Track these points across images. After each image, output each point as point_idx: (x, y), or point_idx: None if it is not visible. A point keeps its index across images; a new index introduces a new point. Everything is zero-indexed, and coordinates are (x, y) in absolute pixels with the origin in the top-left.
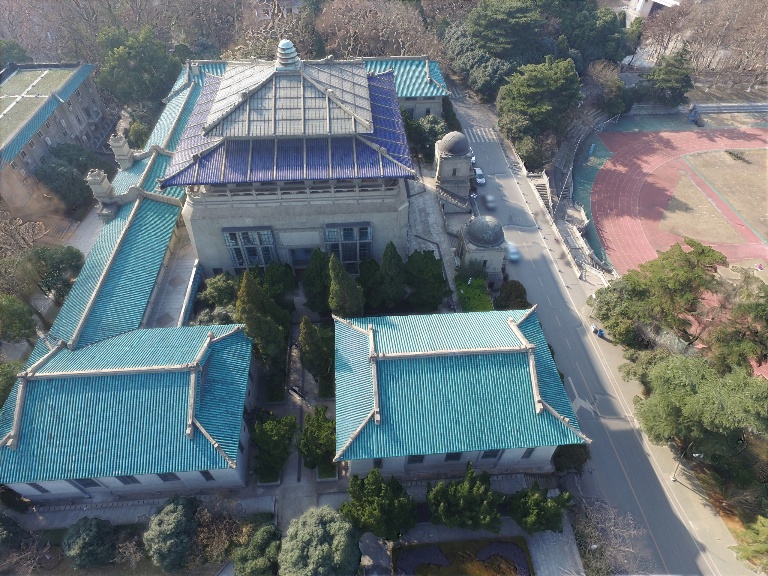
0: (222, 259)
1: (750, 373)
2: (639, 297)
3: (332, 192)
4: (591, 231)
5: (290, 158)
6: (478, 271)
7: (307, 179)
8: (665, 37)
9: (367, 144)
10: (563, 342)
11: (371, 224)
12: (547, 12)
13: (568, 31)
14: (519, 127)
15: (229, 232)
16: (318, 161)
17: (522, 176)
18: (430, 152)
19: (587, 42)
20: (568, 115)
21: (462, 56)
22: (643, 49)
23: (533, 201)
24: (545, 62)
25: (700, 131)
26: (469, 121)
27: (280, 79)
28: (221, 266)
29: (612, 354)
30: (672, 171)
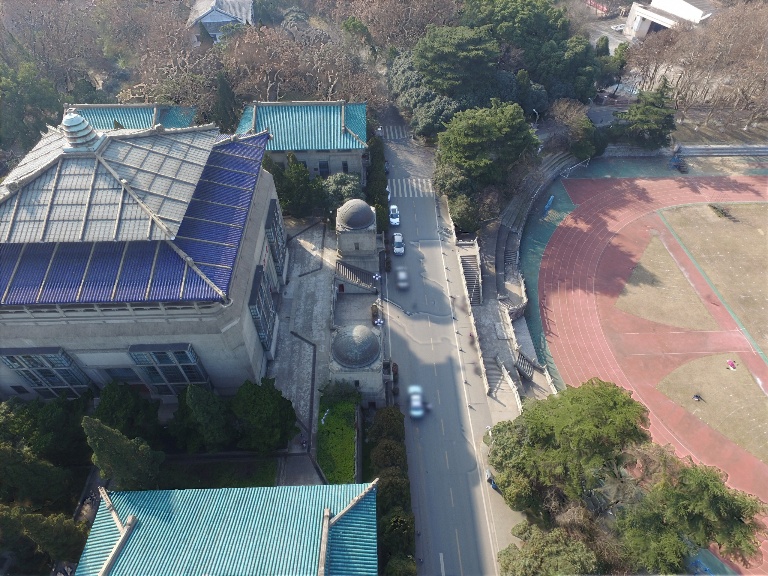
0: (17, 377)
1: (678, 568)
2: (543, 444)
3: (130, 310)
4: (533, 309)
5: (68, 269)
6: (346, 394)
7: (80, 301)
8: (651, 67)
9: (174, 250)
10: (446, 495)
11: (189, 347)
12: (508, 42)
13: (533, 63)
14: (453, 184)
15: (4, 355)
16: (103, 275)
17: (451, 244)
18: (335, 218)
19: (554, 76)
20: (525, 162)
21: (406, 92)
22: (626, 80)
23: (456, 279)
24: (502, 99)
25: (683, 179)
26: (406, 169)
27: (69, 163)
28: (20, 384)
29: (505, 518)
30: (642, 230)
